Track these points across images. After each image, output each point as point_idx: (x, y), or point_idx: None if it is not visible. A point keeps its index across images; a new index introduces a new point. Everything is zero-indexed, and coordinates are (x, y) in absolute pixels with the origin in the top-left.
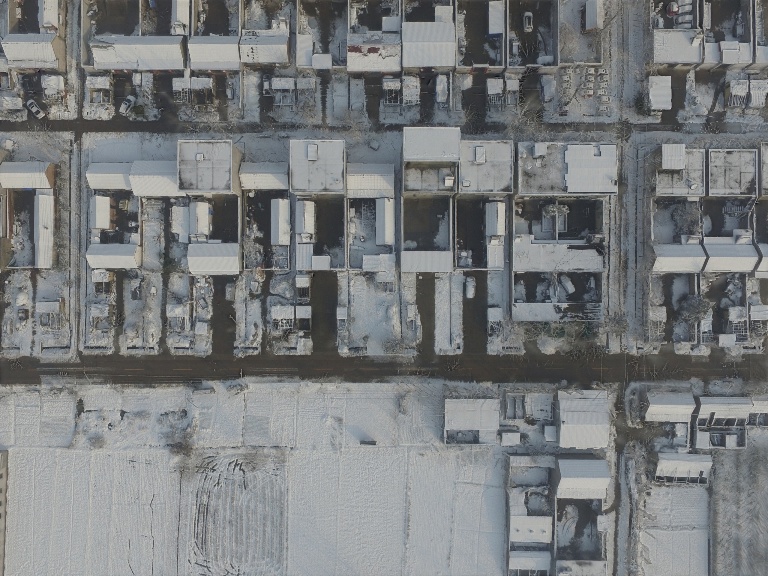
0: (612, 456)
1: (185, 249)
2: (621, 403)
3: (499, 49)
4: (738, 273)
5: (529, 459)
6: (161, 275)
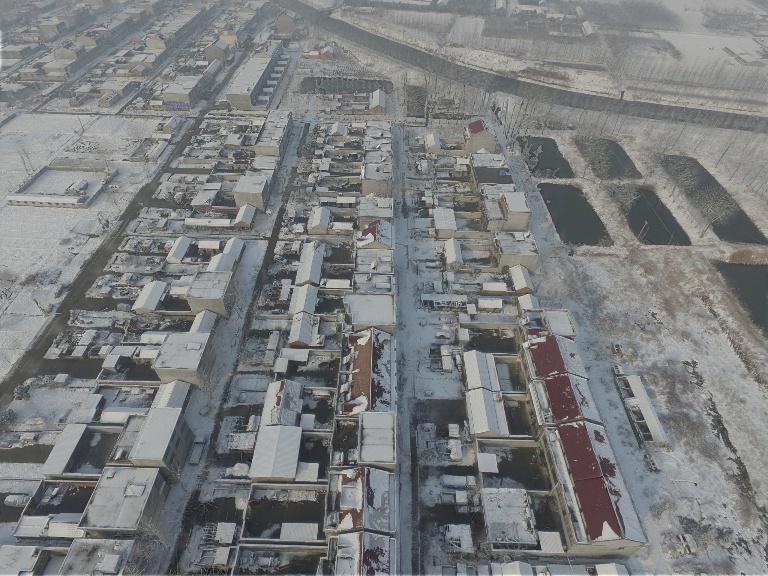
0: None
1: (168, 284)
2: None
3: None
4: None
5: None
6: None
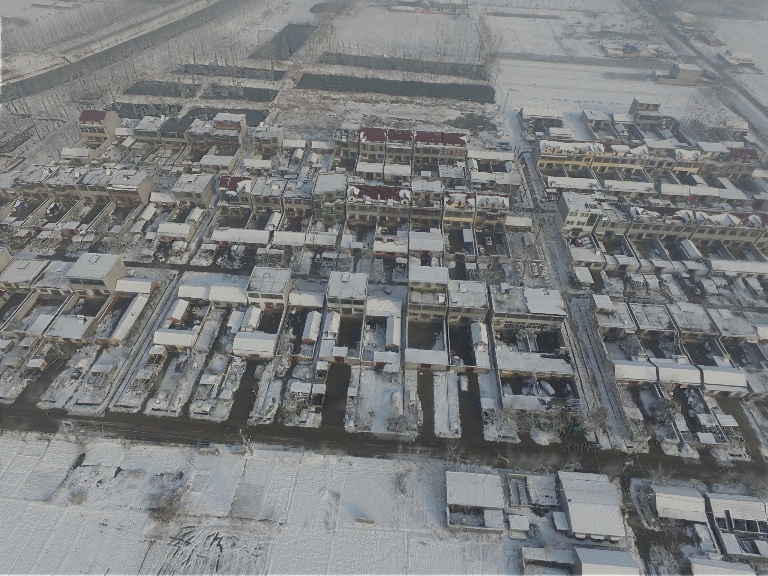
0: (638, 563)
1: (232, 338)
2: (629, 500)
3: (472, 251)
4: (692, 389)
5: (543, 551)
6: (206, 356)
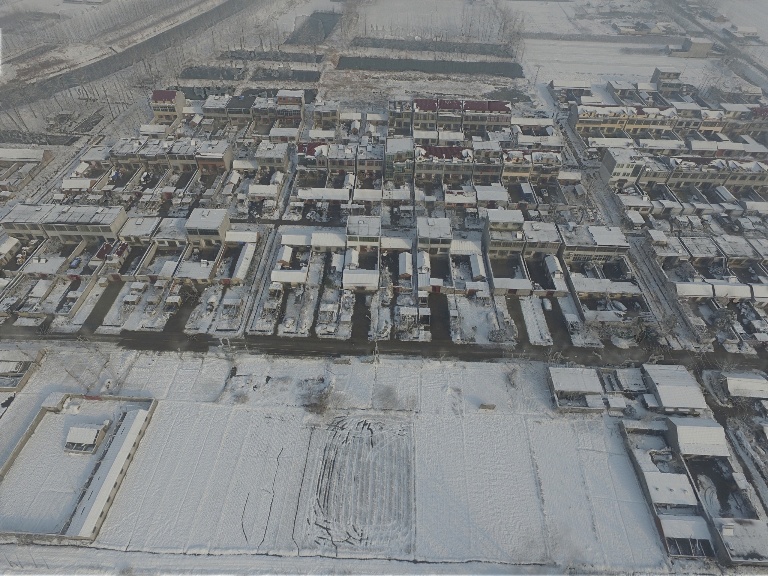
0: None
1: (338, 276)
2: (703, 386)
3: (531, 201)
4: (743, 303)
5: (640, 422)
6: (318, 291)
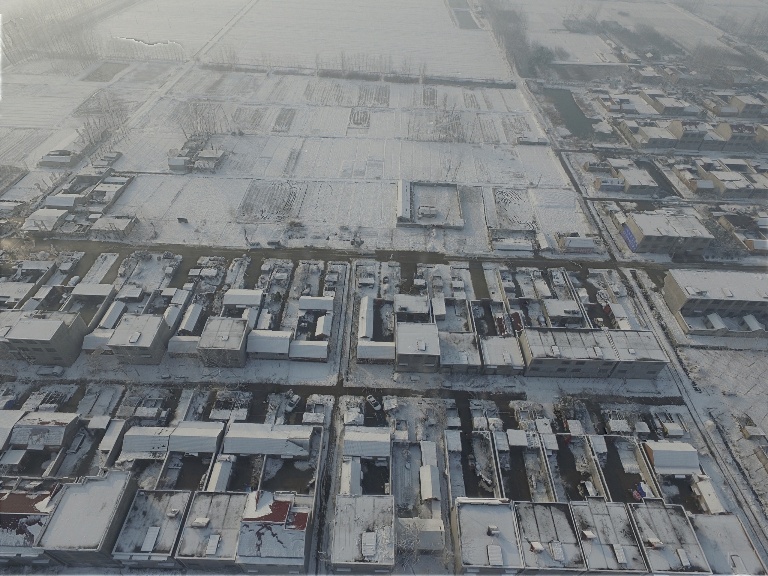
0: None
1: None
2: None
3: None
4: None
5: (91, 210)
6: None
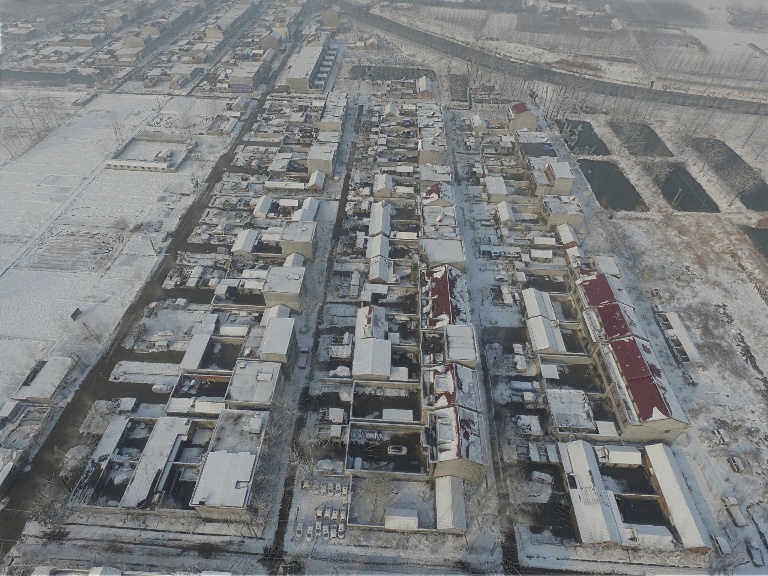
0: None
1: None
2: None
3: None
4: None
5: None
6: None
